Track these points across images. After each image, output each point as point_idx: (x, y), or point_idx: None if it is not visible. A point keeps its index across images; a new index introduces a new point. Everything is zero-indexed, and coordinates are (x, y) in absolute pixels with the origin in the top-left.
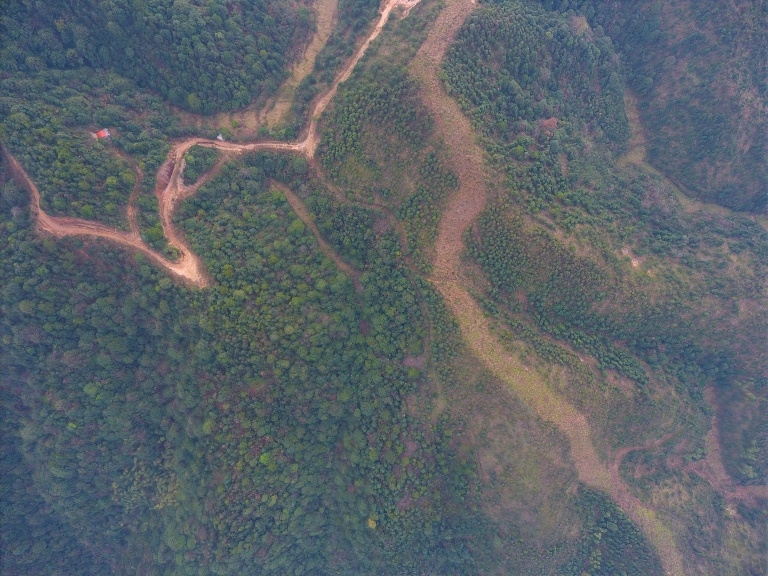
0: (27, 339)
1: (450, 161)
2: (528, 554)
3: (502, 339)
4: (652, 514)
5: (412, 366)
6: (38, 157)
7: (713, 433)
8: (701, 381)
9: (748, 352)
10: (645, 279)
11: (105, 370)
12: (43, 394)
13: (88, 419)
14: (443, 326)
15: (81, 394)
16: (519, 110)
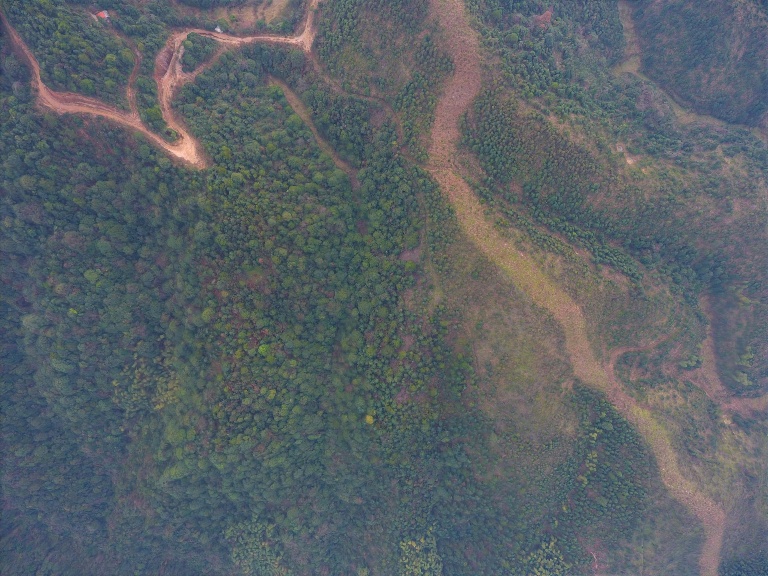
0: (28, 221)
1: (445, 44)
2: (524, 450)
3: (497, 225)
4: (647, 413)
5: (409, 260)
6: (38, 27)
7: (708, 343)
8: (696, 288)
9: (742, 255)
10: (639, 174)
11: (105, 257)
12: (44, 281)
13: (89, 306)
14: (439, 214)
15: (82, 279)
16: (514, 3)
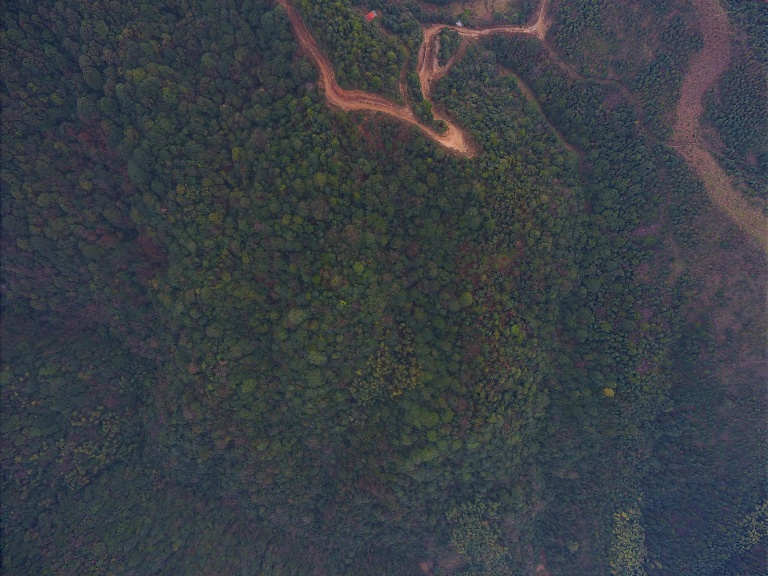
0: (307, 217)
1: (697, 23)
2: (759, 412)
3: (746, 194)
4: None
5: (645, 235)
6: (338, 28)
7: None
8: None
9: None
10: None
11: (369, 249)
12: (312, 275)
13: (355, 297)
14: (686, 187)
15: (352, 271)
16: None
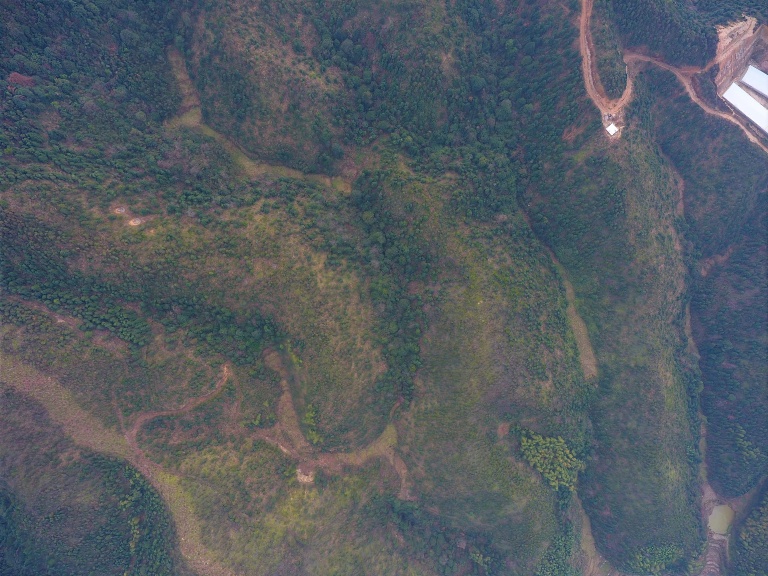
0: None
1: None
2: None
3: None
4: (175, 480)
5: None
6: None
7: (287, 399)
8: (253, 345)
9: (284, 314)
10: (131, 237)
11: None
12: None
13: None
14: None
15: None
16: None
